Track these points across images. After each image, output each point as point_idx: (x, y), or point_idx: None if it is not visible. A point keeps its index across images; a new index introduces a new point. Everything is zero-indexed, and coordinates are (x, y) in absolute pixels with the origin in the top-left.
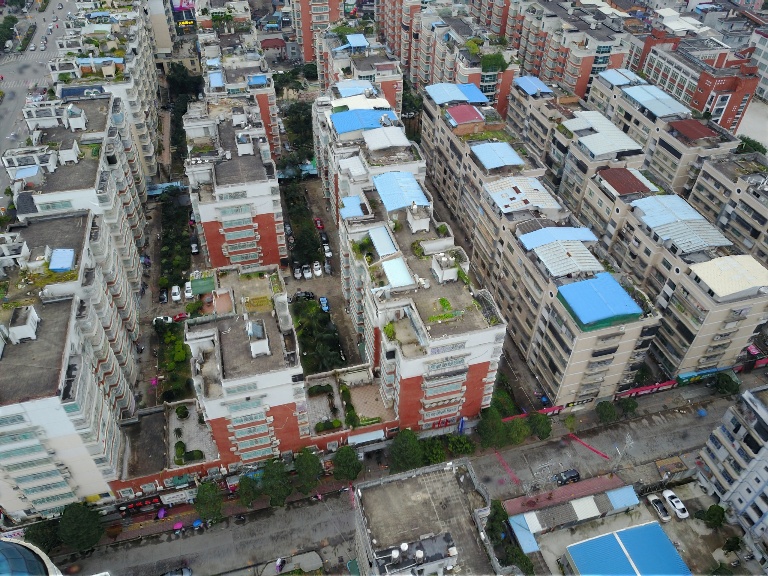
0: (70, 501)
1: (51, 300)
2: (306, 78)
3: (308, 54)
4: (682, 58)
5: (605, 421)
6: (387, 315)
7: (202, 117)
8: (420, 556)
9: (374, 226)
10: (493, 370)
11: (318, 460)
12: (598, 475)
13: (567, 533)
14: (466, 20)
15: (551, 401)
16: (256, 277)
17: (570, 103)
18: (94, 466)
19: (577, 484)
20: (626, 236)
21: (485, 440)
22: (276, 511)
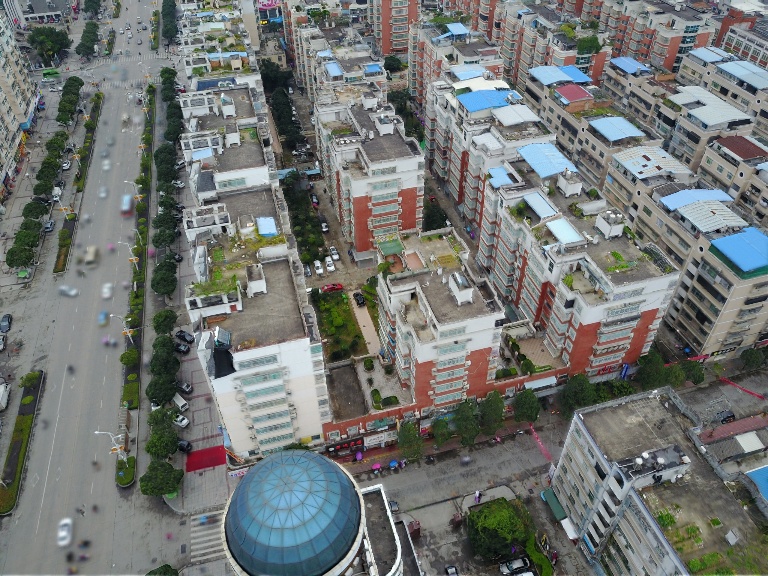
0: (289, 442)
1: (267, 261)
2: (386, 70)
3: (386, 47)
4: (761, 36)
5: (747, 368)
6: (562, 268)
7: (333, 103)
8: (662, 462)
9: (528, 192)
10: (659, 317)
11: (503, 403)
12: (751, 415)
13: (734, 465)
14: (551, 7)
15: (696, 351)
16: (436, 239)
17: (667, 80)
18: (316, 407)
19: (733, 423)
20: (750, 198)
21: (647, 384)
22: (460, 452)
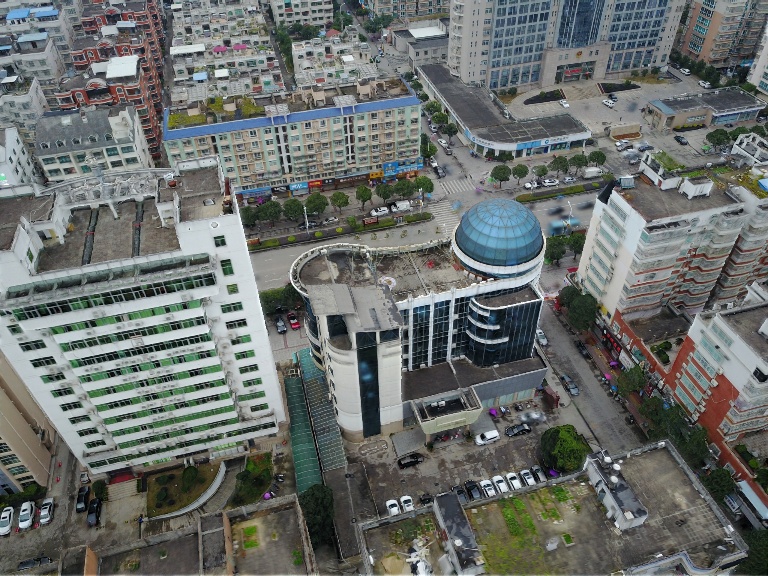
0: (597, 297)
1: (730, 194)
2: None
3: None
4: None
5: None
6: None
7: None
8: (612, 479)
9: None
10: None
11: (704, 454)
12: None
13: None
14: None
15: None
16: None
17: None
18: (621, 289)
19: None
20: None
21: None
22: None
